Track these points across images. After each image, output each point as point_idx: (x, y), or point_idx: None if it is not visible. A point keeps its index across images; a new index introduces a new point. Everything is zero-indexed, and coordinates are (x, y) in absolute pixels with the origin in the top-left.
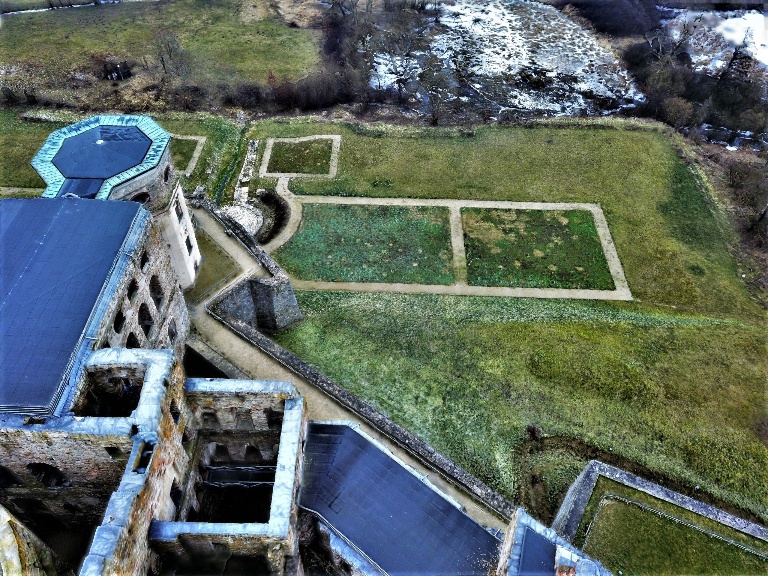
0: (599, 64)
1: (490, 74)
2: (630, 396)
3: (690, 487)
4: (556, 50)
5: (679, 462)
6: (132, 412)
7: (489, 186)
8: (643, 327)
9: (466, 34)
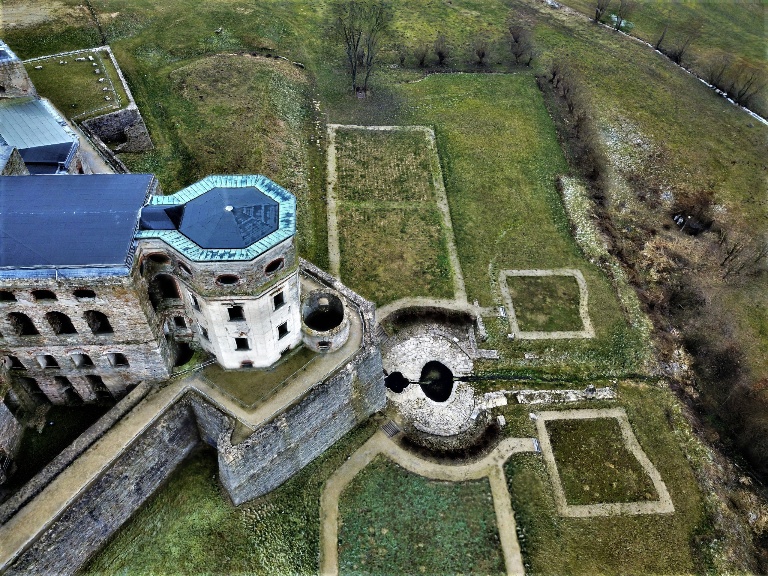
0: None
1: None
2: None
3: None
4: None
5: None
6: None
7: None
8: None
9: None
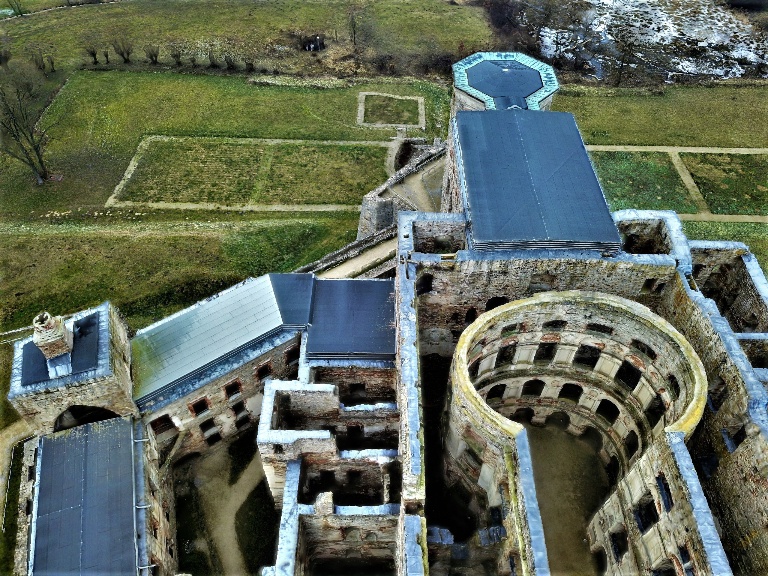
0: (743, 35)
1: (647, 44)
2: None
3: None
4: (699, 23)
5: None
6: (671, 251)
7: (696, 135)
8: None
9: (611, 10)
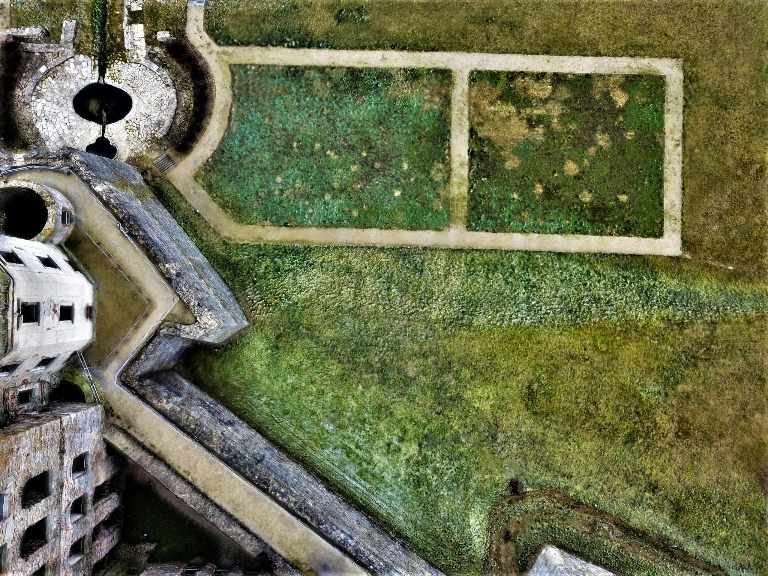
0: None
1: None
2: (635, 439)
3: (668, 544)
4: None
5: (665, 518)
6: None
7: (519, 19)
8: (679, 325)
9: None
